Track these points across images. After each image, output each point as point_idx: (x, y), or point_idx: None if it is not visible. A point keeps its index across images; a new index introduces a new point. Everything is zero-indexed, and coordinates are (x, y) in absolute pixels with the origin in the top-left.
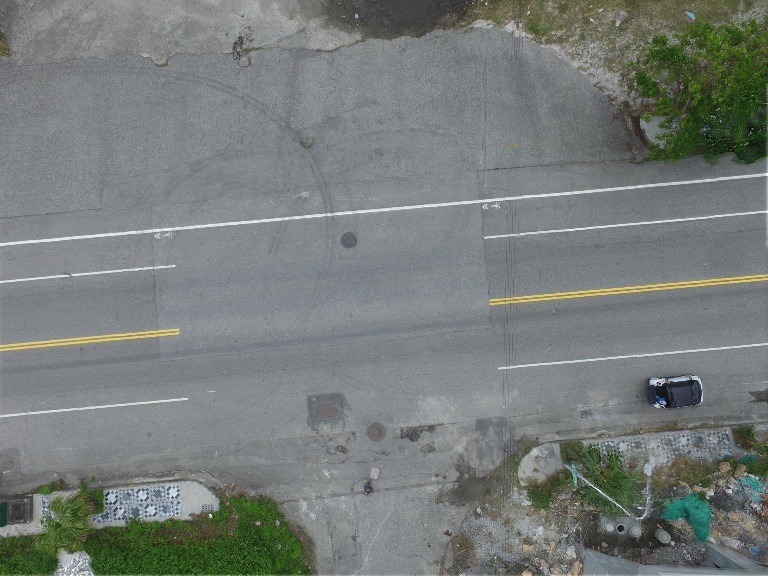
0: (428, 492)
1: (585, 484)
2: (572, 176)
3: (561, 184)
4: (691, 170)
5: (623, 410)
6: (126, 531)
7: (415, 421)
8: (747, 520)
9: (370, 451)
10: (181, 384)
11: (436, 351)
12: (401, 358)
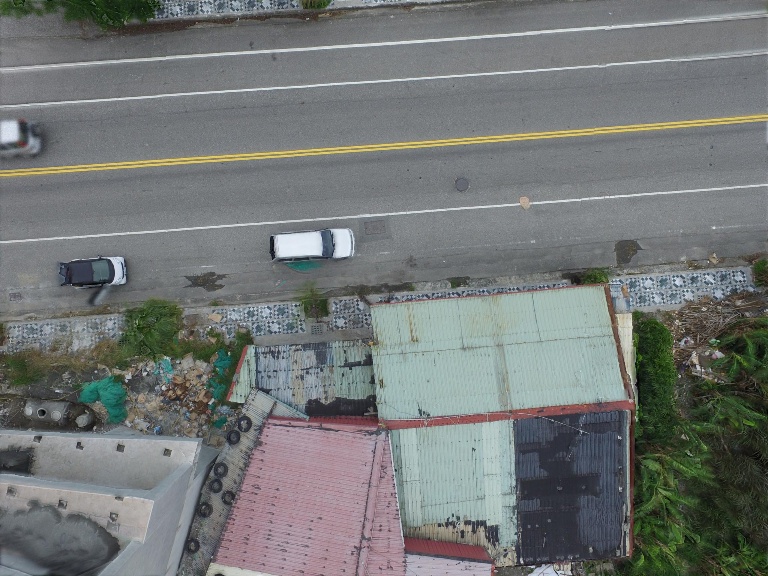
0: None
1: None
2: (17, 51)
3: (4, 59)
4: (139, 47)
5: (51, 293)
6: None
7: None
8: (155, 402)
9: None
10: None
11: None
12: None
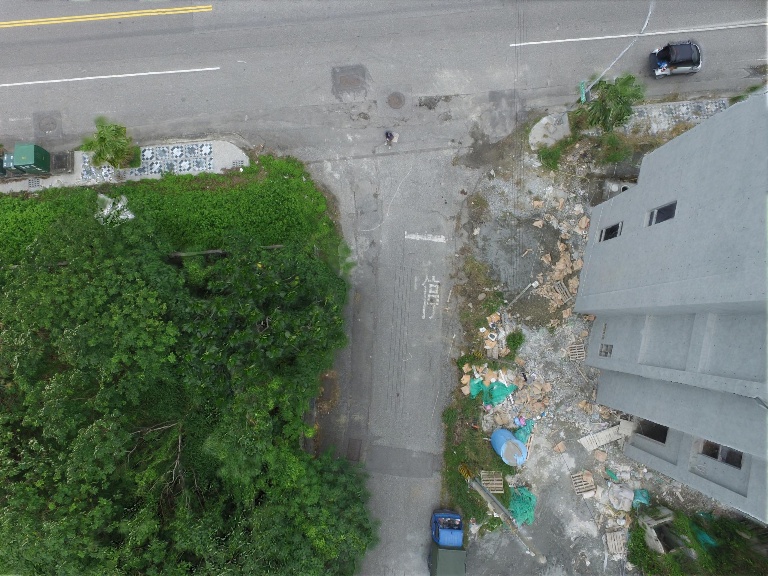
0: (445, 155)
1: (593, 98)
2: None
3: None
4: None
5: None
6: (162, 181)
7: (432, 91)
8: None
9: (390, 117)
10: (213, 54)
11: (452, 29)
12: (419, 34)
